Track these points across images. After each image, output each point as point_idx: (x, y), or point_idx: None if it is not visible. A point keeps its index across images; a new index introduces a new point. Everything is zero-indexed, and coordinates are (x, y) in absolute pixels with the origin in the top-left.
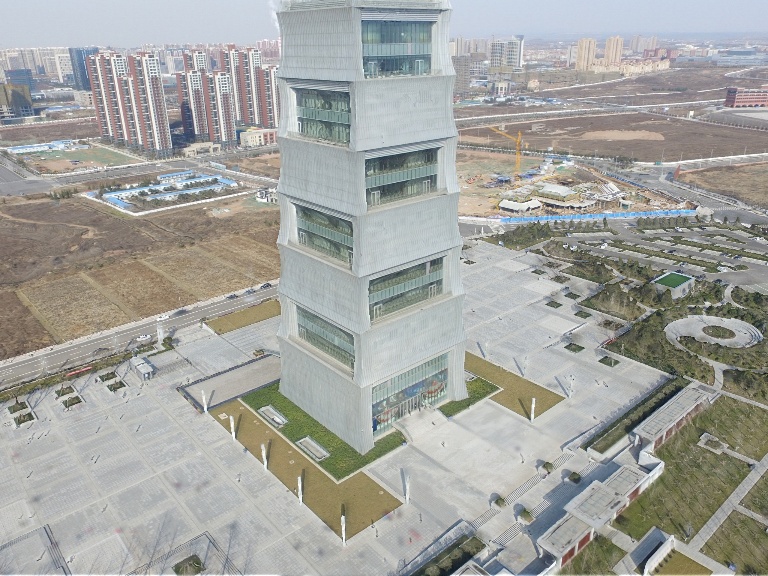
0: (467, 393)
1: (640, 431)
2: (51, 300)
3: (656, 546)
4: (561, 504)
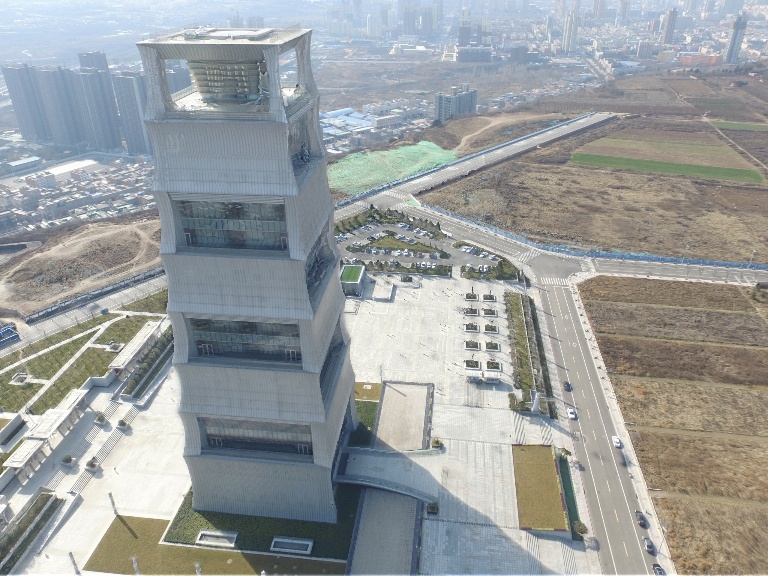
0: (194, 506)
1: (0, 507)
2: (762, 402)
3: (10, 440)
4: (78, 440)
